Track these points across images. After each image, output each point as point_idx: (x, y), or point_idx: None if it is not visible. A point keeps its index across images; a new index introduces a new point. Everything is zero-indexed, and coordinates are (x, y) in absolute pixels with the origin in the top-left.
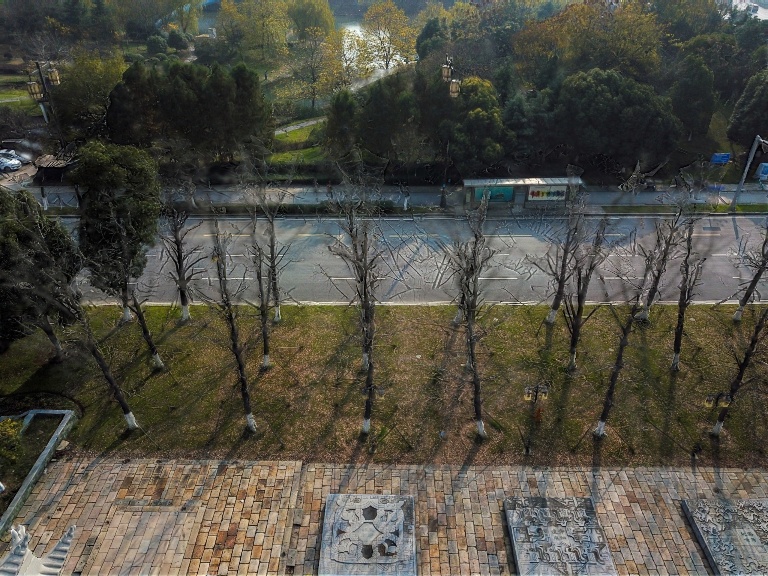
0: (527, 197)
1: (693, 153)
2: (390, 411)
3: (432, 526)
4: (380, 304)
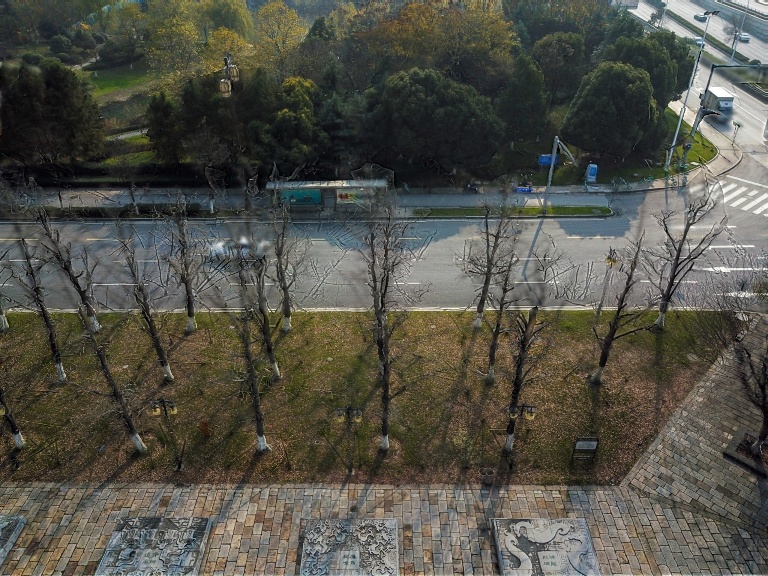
0: (336, 200)
1: (532, 154)
2: (59, 425)
3: (30, 549)
4: (124, 311)
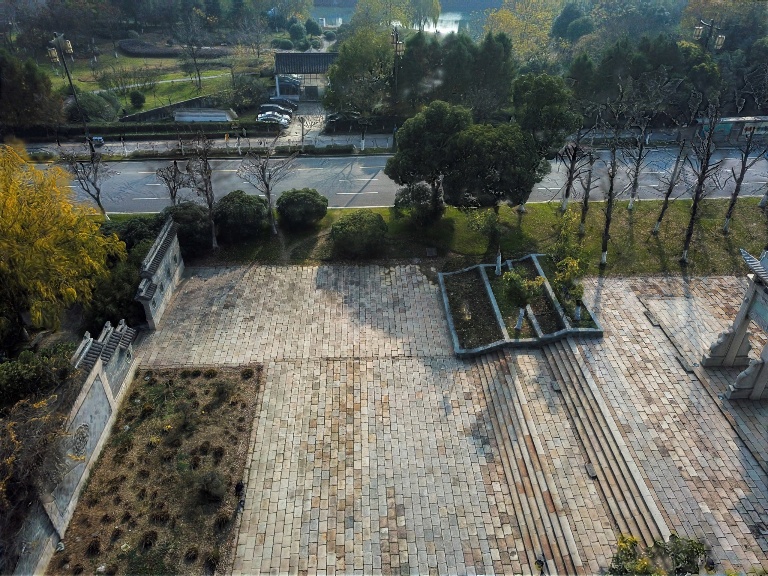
0: (741, 132)
1: None
2: None
3: None
4: None
